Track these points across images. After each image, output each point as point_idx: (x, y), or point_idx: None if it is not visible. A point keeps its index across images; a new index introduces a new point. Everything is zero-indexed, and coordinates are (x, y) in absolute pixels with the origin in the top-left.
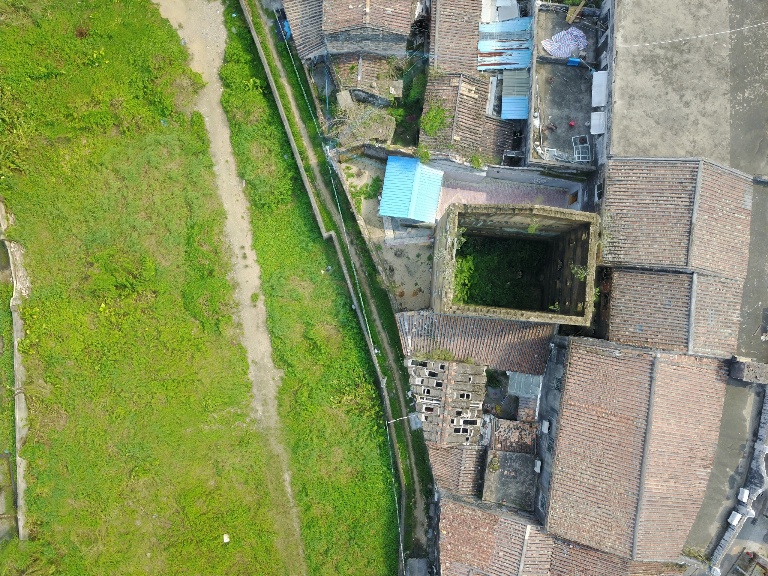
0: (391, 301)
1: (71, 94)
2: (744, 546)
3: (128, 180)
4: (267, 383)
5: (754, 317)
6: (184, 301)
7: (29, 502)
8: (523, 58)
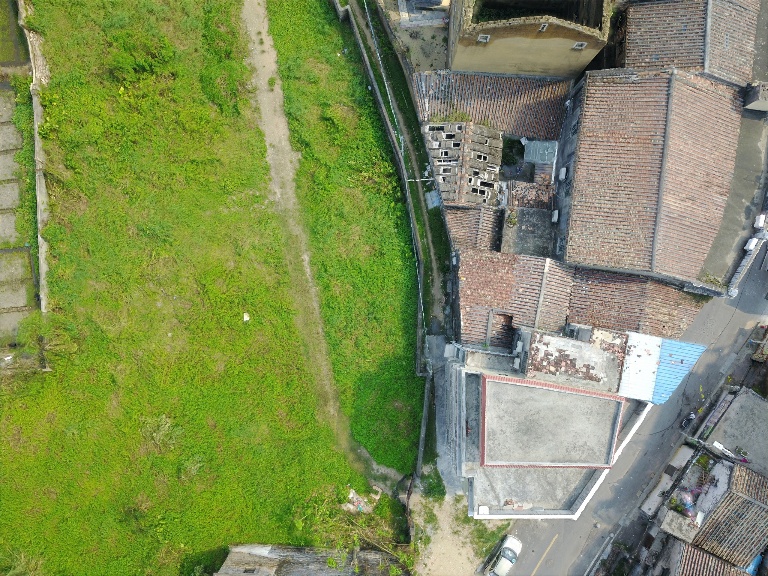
0: (408, 68)
1: None
2: (758, 321)
3: None
4: (285, 166)
5: (767, 49)
6: (202, 85)
7: (51, 284)
8: None
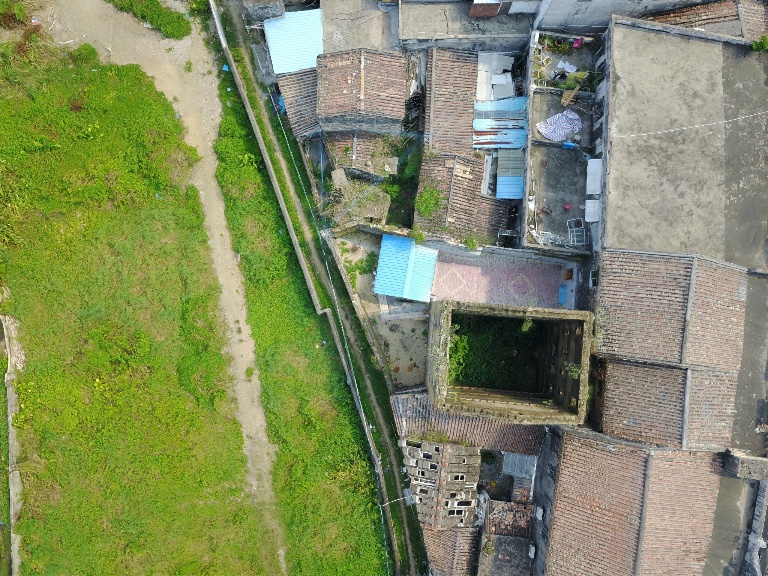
0: (386, 381)
1: (66, 168)
2: None
3: (123, 255)
4: (262, 458)
5: (748, 409)
6: (179, 376)
7: None
8: (518, 138)
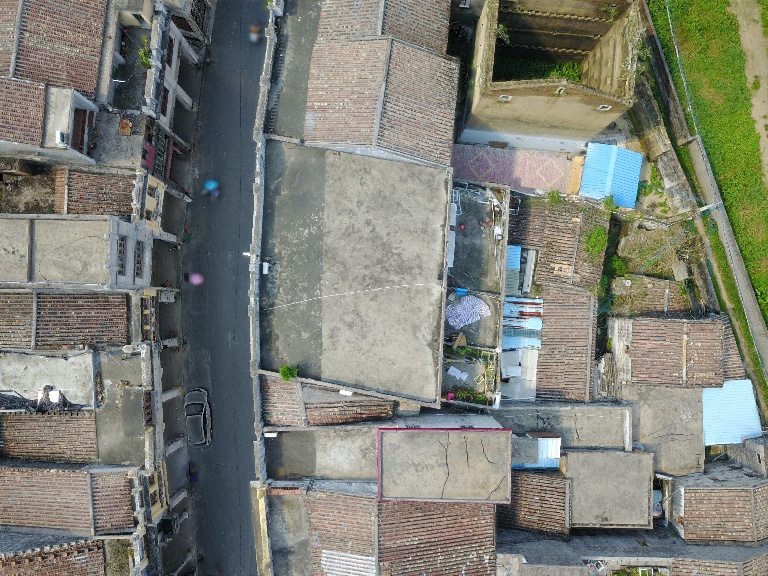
0: None
1: None
2: None
3: None
4: (743, 0)
5: (306, 6)
6: None
7: None
8: None
